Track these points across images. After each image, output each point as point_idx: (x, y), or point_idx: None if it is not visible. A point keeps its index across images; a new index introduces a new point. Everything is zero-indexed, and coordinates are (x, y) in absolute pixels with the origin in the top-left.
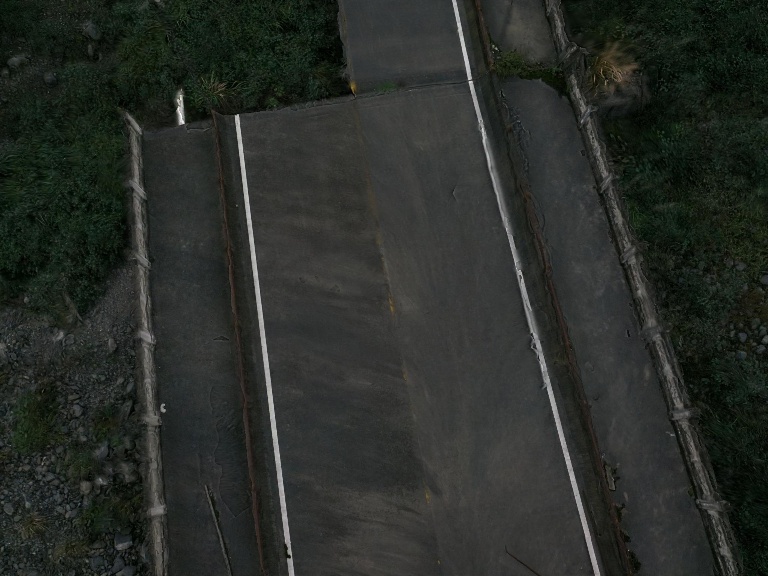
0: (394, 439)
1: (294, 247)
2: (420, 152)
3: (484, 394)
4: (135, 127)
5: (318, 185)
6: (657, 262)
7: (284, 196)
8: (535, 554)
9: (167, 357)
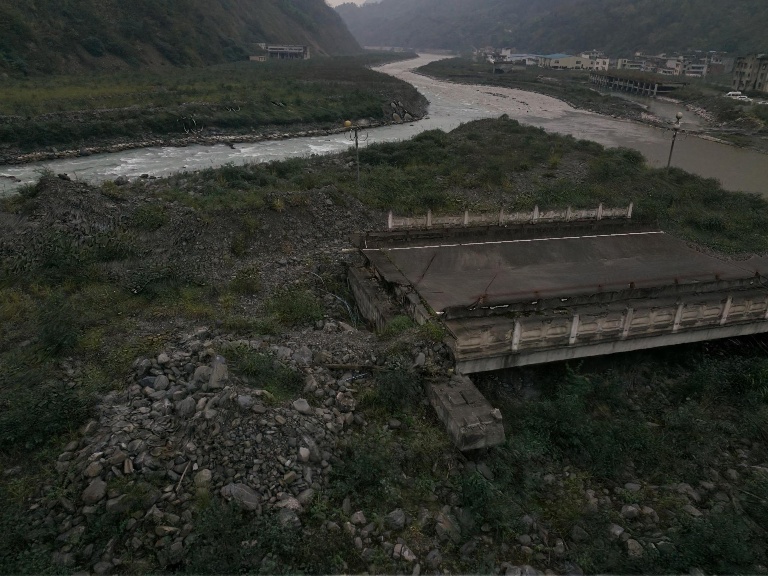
0: (533, 261)
1: (610, 247)
2: (708, 272)
3: (578, 280)
4: (629, 212)
5: (652, 252)
6: (760, 408)
7: (635, 245)
8: (499, 290)
9: (529, 226)
